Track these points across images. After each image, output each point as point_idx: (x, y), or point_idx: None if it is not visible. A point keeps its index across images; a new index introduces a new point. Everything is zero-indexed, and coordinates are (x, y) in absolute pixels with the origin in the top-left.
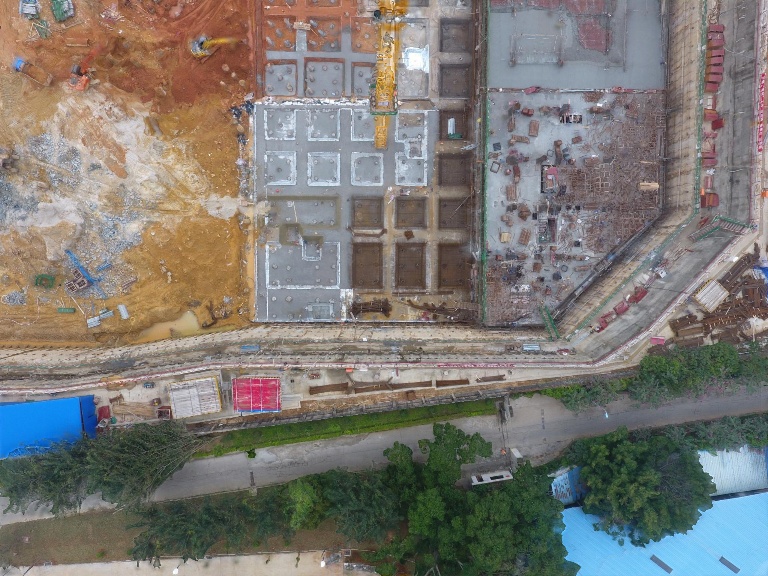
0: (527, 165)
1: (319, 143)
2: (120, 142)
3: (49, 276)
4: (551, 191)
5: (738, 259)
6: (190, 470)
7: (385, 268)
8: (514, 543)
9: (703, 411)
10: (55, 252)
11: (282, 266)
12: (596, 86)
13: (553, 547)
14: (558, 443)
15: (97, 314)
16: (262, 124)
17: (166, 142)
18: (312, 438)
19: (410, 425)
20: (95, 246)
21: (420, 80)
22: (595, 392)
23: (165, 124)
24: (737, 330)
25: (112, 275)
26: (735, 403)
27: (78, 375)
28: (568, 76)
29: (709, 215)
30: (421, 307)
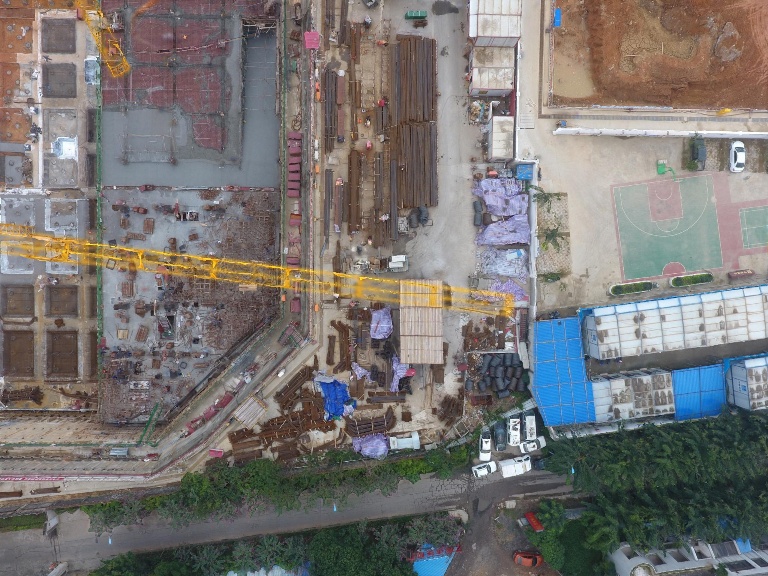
0: (144, 262)
1: None
2: None
3: None
4: (169, 288)
5: (298, 371)
6: None
7: (35, 356)
8: None
9: (261, 525)
10: None
11: None
12: (212, 184)
13: None
14: (112, 557)
15: None
16: None
17: None
18: None
19: None
20: None
21: (72, 169)
22: None
23: None
24: (297, 443)
25: None
26: (294, 518)
27: None
28: (184, 174)
29: (298, 320)
30: (73, 395)
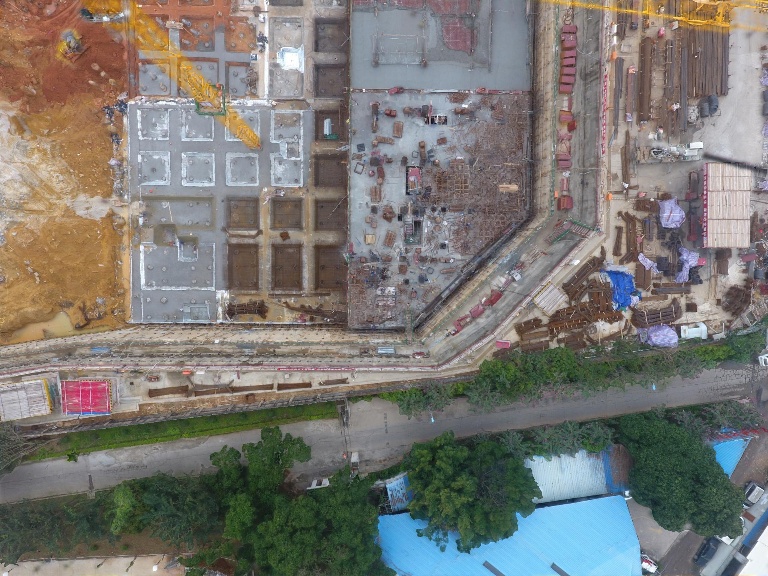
0: (392, 166)
1: (193, 143)
2: None
3: None
4: (416, 193)
5: (584, 262)
6: (27, 473)
7: (261, 269)
8: (319, 549)
9: (549, 416)
10: None
11: (158, 267)
12: (461, 87)
13: (358, 553)
14: (401, 447)
15: None
16: (135, 124)
17: (31, 141)
18: (149, 441)
19: (248, 428)
20: None
21: (296, 80)
22: (430, 396)
23: (35, 123)
24: (583, 334)
25: None
26: (581, 408)
27: None
28: (432, 77)
29: None
30: (297, 309)
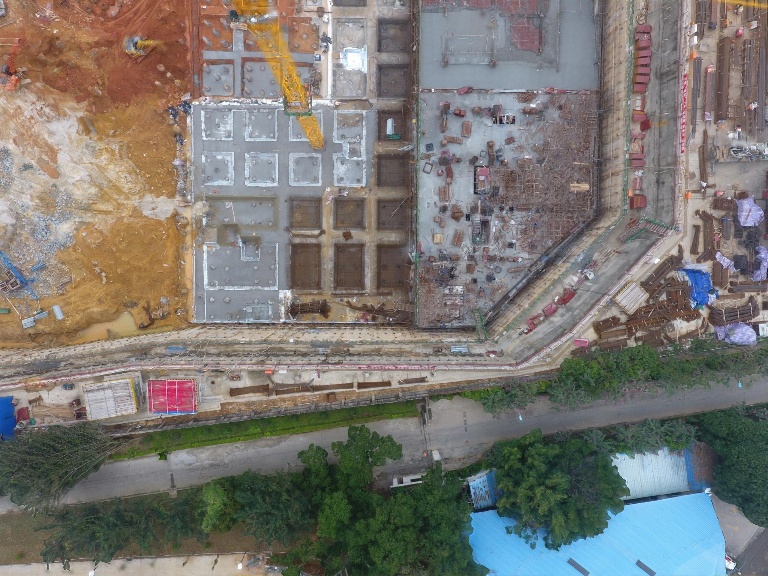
0: (460, 166)
1: (257, 143)
2: (52, 142)
3: None
4: (484, 192)
5: (662, 261)
6: (110, 472)
7: (323, 269)
8: (417, 546)
9: (627, 414)
10: None
11: (220, 267)
12: (529, 87)
13: (457, 550)
14: (480, 445)
15: (32, 315)
16: (199, 124)
17: (99, 142)
18: (231, 440)
19: (330, 427)
20: (28, 246)
21: (358, 80)
22: (513, 394)
23: (100, 124)
24: (661, 332)
25: (46, 276)
26: (659, 406)
27: (2, 376)
28: (501, 77)
29: (638, 216)
30: (360, 308)
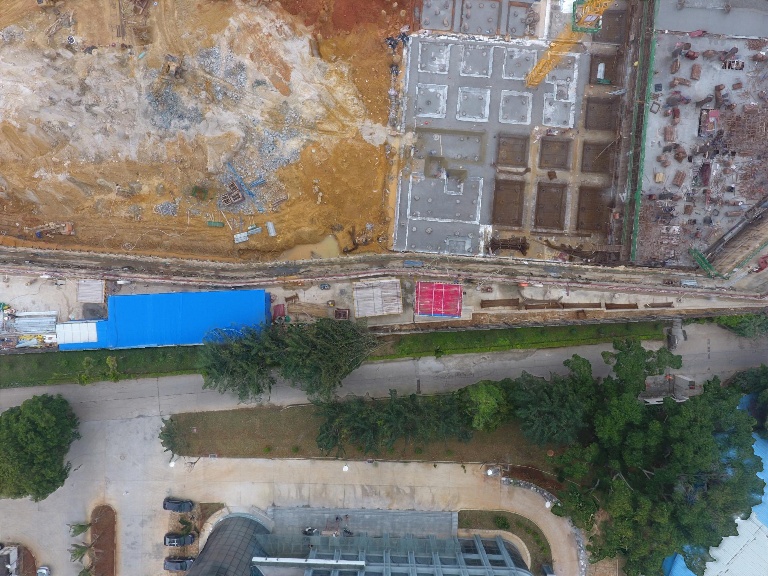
0: (686, 108)
1: (471, 79)
2: (287, 60)
3: (202, 189)
4: (708, 135)
5: None
6: (359, 373)
7: (526, 206)
8: None
9: None
10: (214, 164)
11: (424, 198)
12: (760, 34)
13: (750, 456)
14: (722, 373)
15: (245, 230)
16: (416, 56)
17: (329, 64)
18: (483, 349)
19: (580, 343)
20: (251, 162)
21: None
22: None
23: (324, 49)
24: None
25: (264, 192)
26: None
27: (246, 277)
28: (733, 23)
29: None
30: (558, 248)
